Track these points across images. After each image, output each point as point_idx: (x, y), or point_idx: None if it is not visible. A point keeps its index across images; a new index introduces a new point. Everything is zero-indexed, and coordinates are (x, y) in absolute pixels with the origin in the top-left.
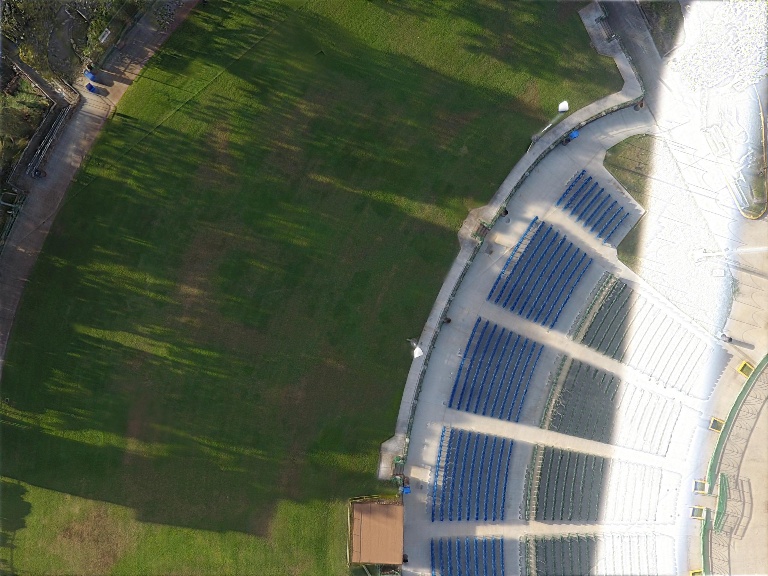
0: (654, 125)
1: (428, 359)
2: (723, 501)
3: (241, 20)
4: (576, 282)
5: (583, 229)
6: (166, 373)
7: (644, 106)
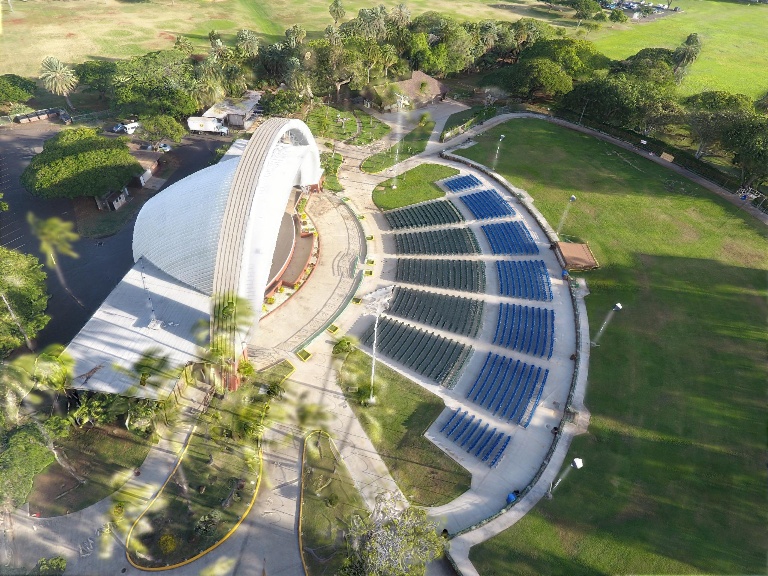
0: None
1: (578, 335)
2: (352, 267)
3: None
4: None
5: None
6: (762, 326)
7: None
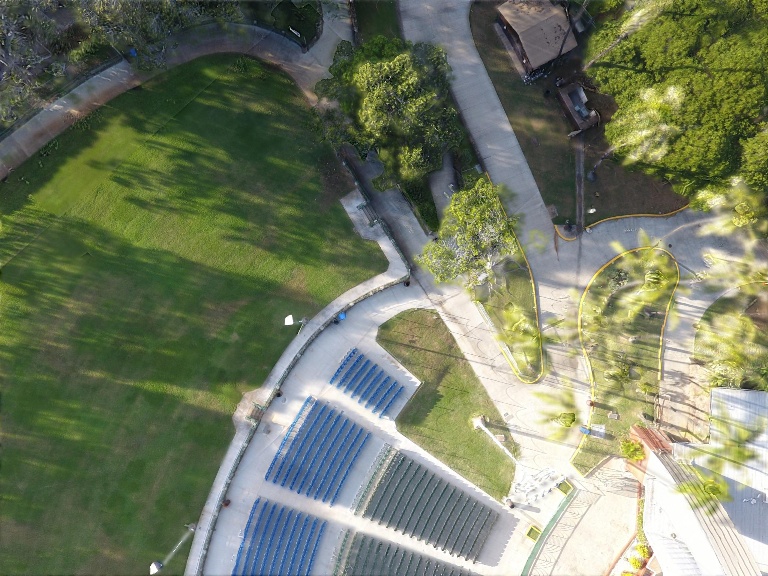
0: (426, 299)
1: (207, 543)
2: None
3: (6, 229)
4: (354, 458)
5: (360, 404)
6: None
7: (414, 281)
